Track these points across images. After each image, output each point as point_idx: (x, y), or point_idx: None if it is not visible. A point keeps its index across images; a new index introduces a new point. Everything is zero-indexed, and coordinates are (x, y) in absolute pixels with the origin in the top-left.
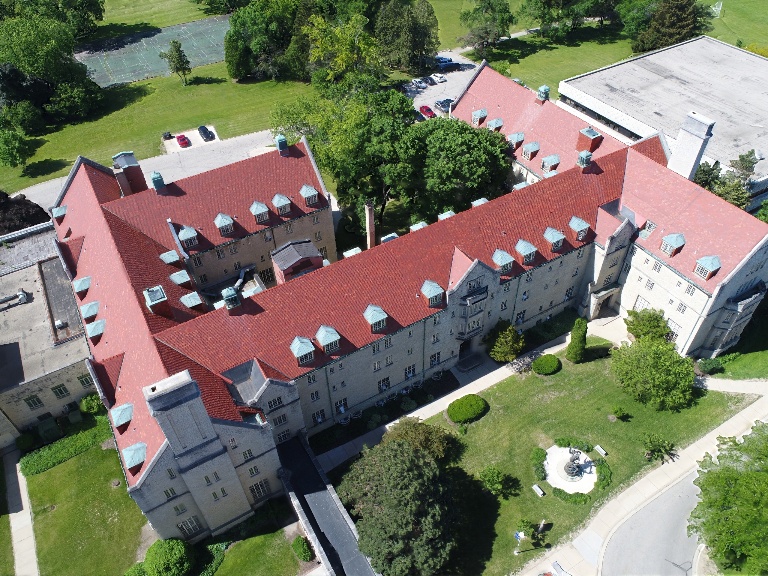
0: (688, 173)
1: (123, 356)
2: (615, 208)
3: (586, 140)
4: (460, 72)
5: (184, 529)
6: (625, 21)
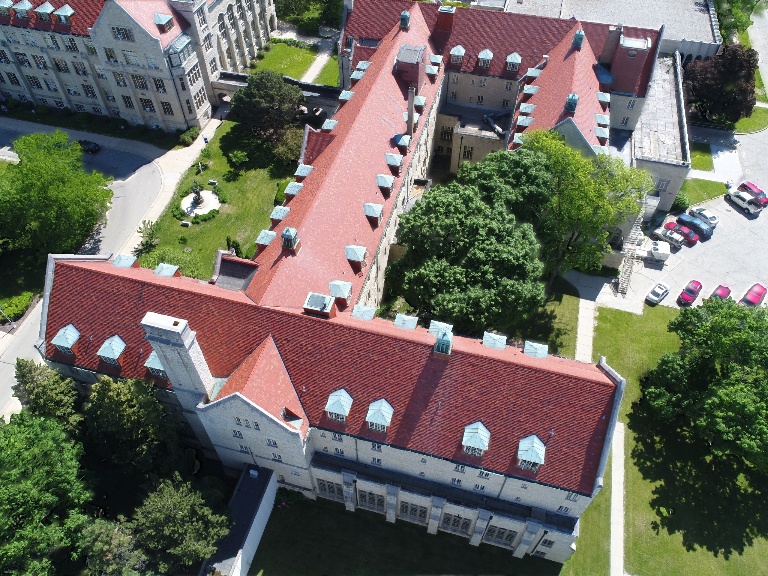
0: None
1: None
2: None
3: None
4: None
5: None
6: None
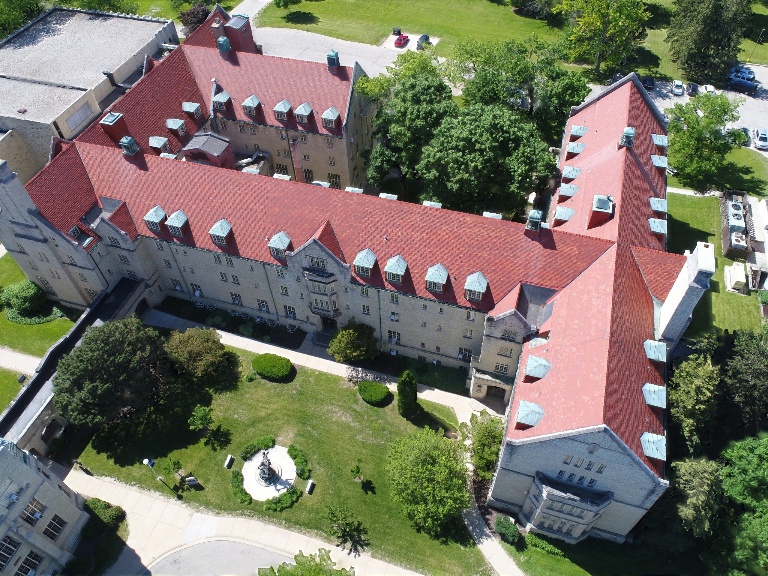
0: (668, 319)
1: None
2: (543, 297)
3: None
4: (748, 97)
5: (44, 284)
6: None
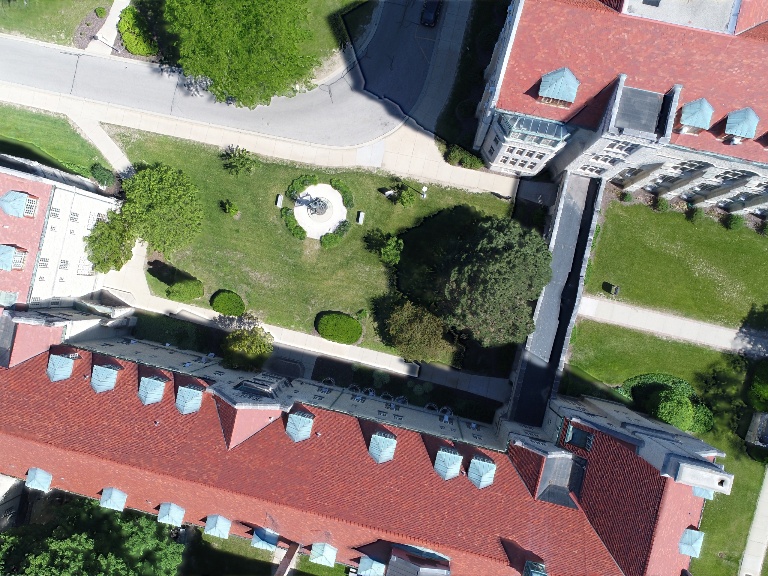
0: None
1: None
2: None
3: None
4: None
5: None
6: None
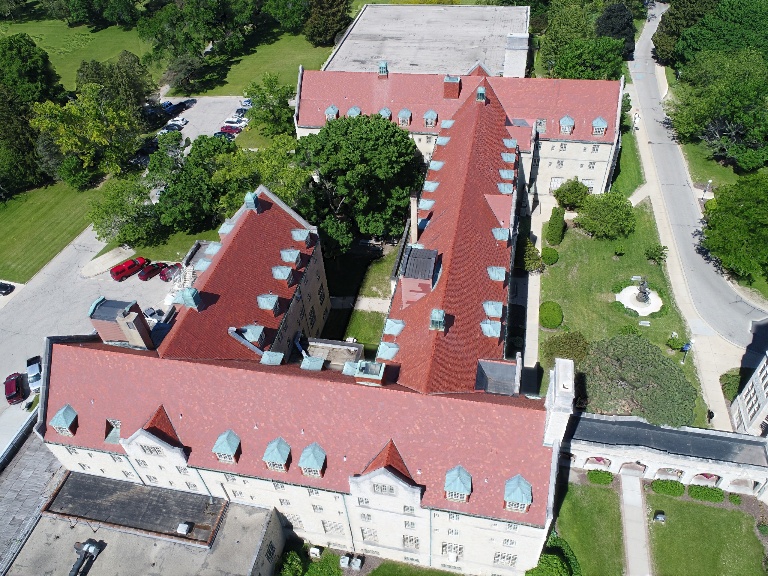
0: None
1: (393, 444)
2: (510, 123)
3: (453, 86)
4: (189, 110)
5: None
6: (279, 18)
